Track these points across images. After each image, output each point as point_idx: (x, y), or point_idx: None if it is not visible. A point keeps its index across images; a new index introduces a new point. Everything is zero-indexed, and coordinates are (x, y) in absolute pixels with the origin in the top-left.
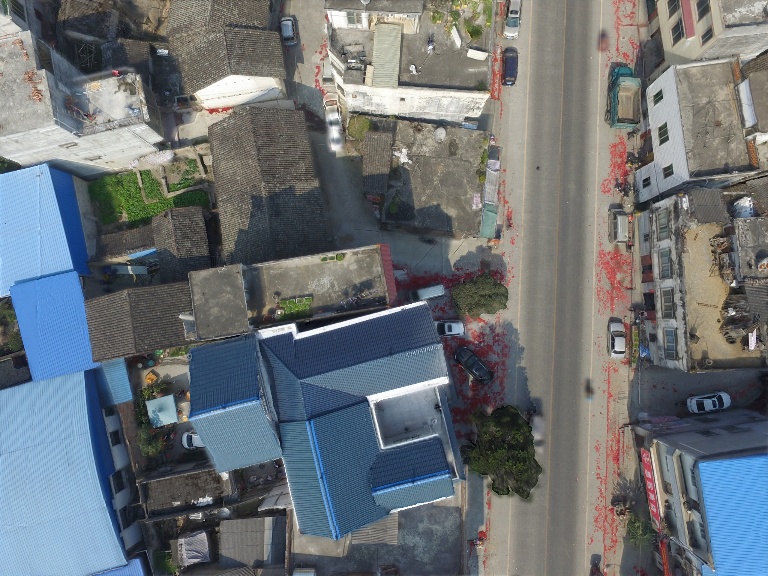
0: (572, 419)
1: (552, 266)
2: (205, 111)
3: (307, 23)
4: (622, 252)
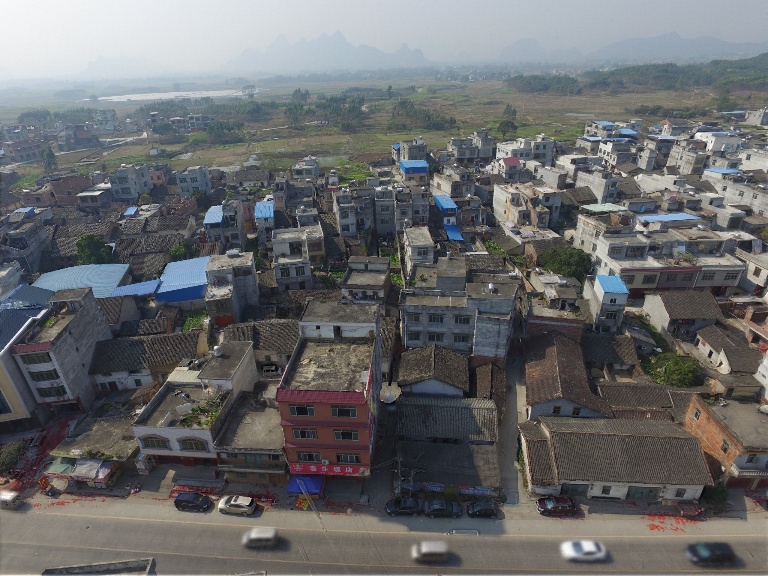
0: None
1: None
2: None
3: None
4: None
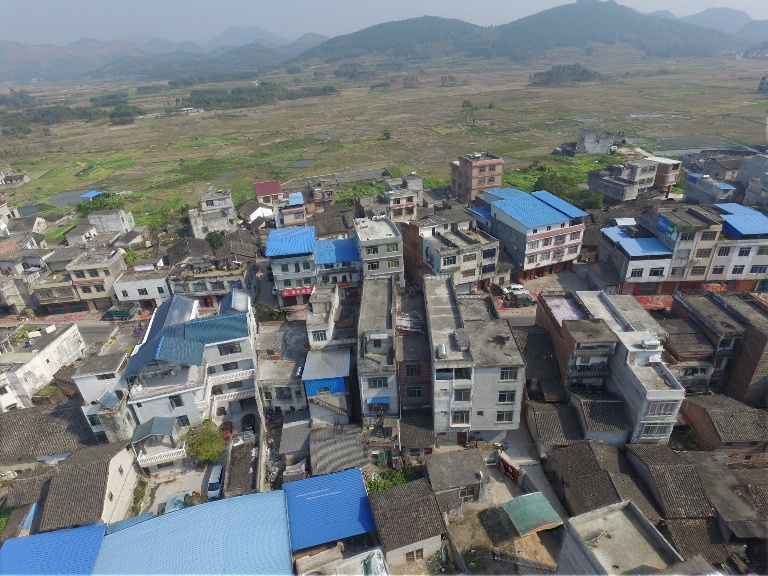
0: None
1: None
2: None
3: None
4: None
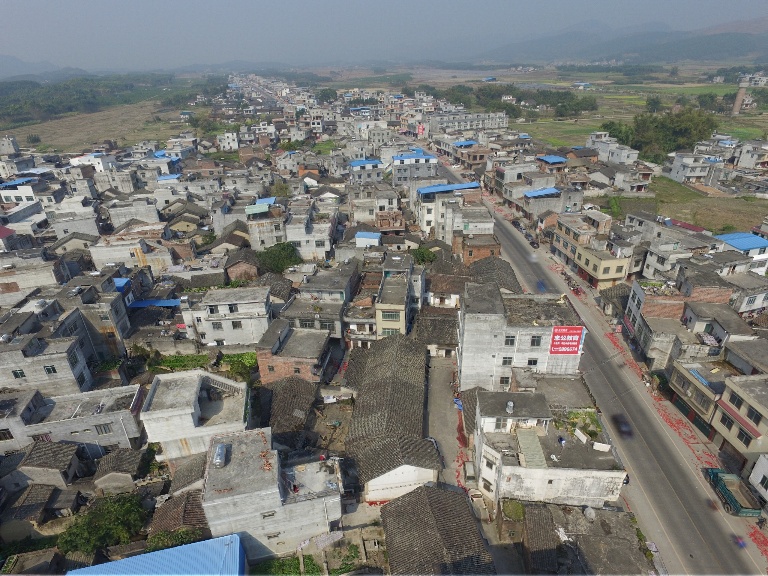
0: None
1: None
2: (365, 503)
3: (443, 442)
4: None
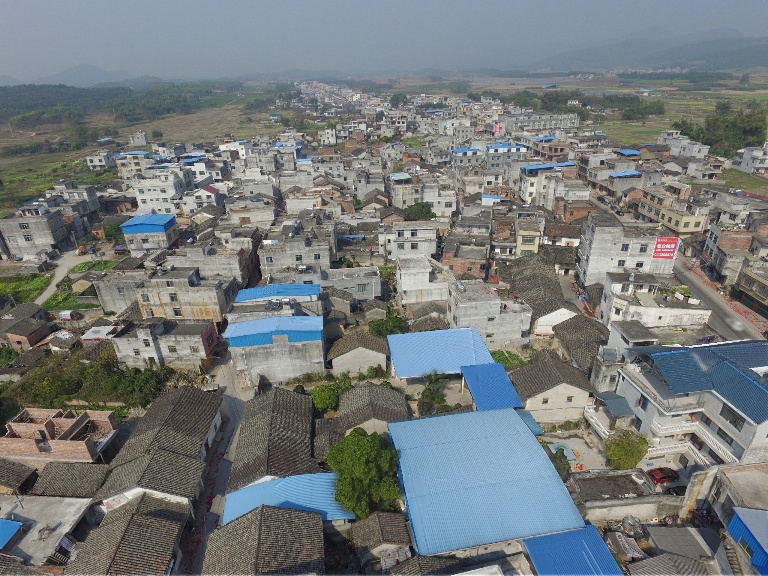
0: None
1: None
2: None
3: None
4: None
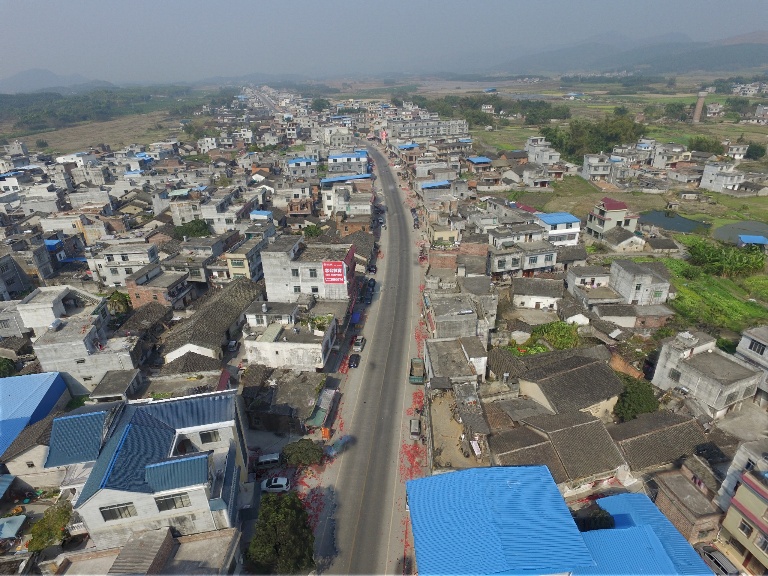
0: (370, 564)
1: (367, 452)
2: None
3: None
4: (420, 446)
